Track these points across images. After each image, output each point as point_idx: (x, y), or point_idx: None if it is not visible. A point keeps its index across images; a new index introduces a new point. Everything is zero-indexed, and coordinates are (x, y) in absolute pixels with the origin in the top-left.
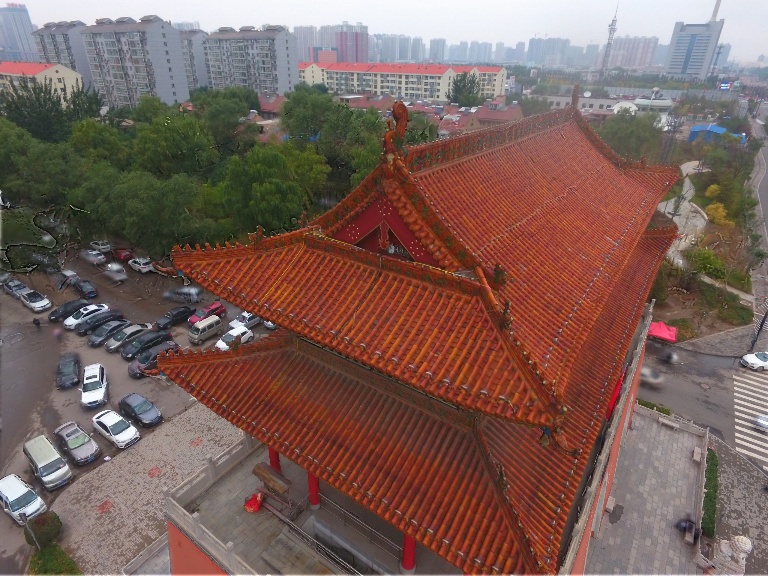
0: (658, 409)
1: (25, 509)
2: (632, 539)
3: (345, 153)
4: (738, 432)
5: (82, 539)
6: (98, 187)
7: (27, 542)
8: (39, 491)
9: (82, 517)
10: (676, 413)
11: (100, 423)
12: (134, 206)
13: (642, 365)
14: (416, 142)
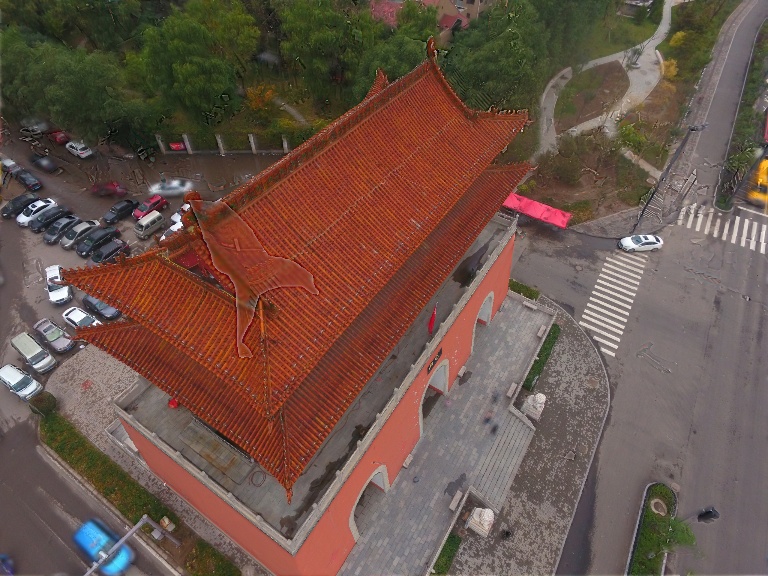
0: (530, 291)
1: (26, 389)
2: (470, 395)
3: (271, 15)
4: (587, 309)
5: (74, 408)
6: (10, 65)
7: (34, 413)
8: (34, 374)
9: (71, 392)
10: (545, 294)
11: (69, 319)
12: (53, 94)
13: (533, 249)
14: (346, 3)
